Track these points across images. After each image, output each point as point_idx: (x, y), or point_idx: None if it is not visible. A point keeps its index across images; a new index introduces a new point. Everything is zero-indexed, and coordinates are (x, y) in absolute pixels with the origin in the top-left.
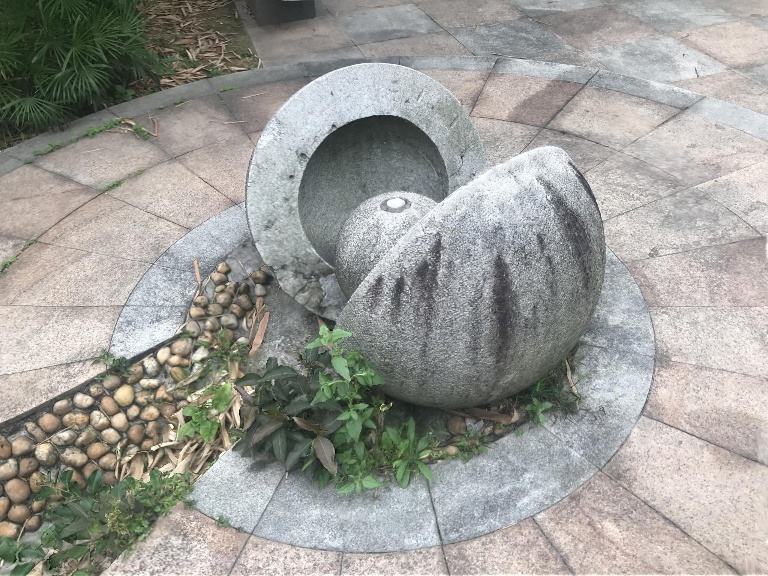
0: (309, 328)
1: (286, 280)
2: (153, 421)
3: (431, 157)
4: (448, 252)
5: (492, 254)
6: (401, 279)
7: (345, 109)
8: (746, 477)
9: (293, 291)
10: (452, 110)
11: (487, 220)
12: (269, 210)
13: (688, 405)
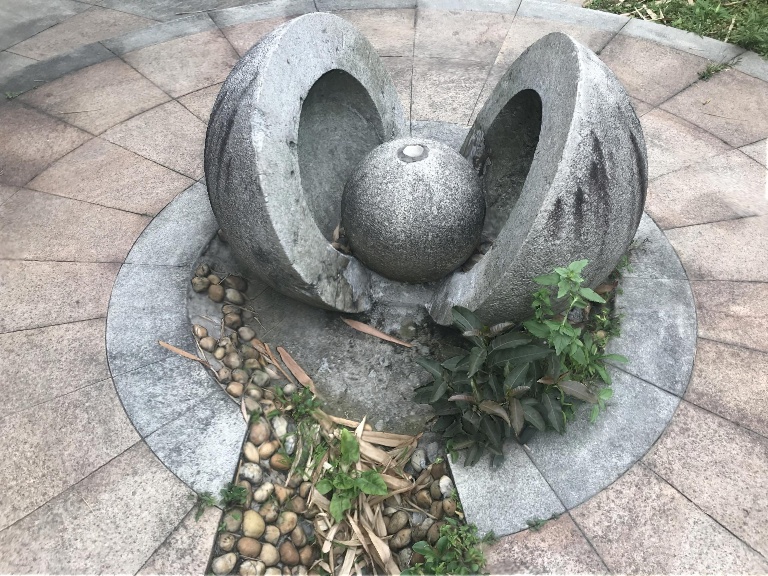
0: (342, 334)
1: (325, 291)
2: (296, 527)
3: (358, 105)
4: (606, 145)
5: (628, 132)
6: (579, 191)
7: (302, 76)
8: (750, 230)
9: (333, 300)
10: (365, 47)
11: (612, 104)
12: (290, 221)
13: (675, 208)
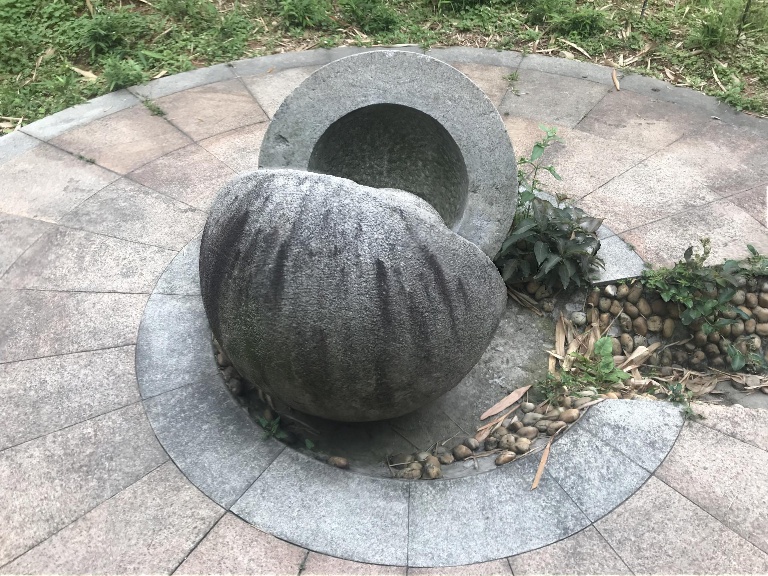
0: None
1: None
2: None
3: None
4: None
5: None
6: None
7: None
8: None
9: None
10: None
11: None
12: None
13: None
